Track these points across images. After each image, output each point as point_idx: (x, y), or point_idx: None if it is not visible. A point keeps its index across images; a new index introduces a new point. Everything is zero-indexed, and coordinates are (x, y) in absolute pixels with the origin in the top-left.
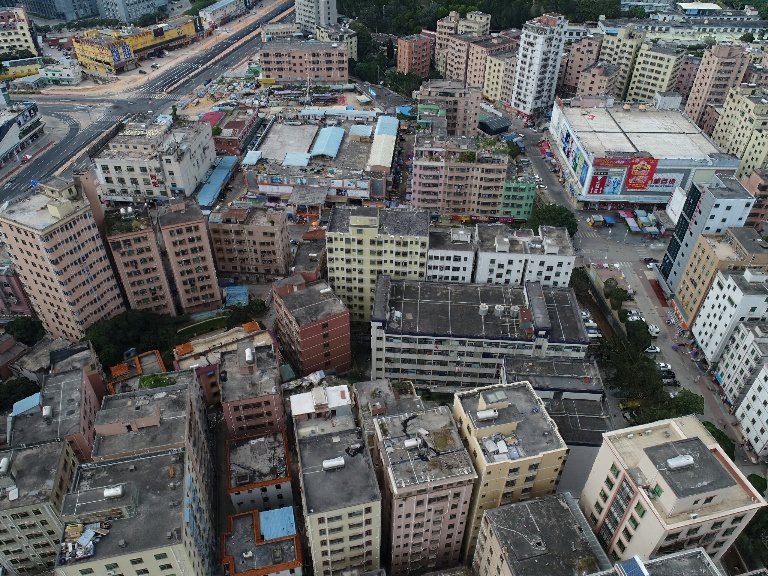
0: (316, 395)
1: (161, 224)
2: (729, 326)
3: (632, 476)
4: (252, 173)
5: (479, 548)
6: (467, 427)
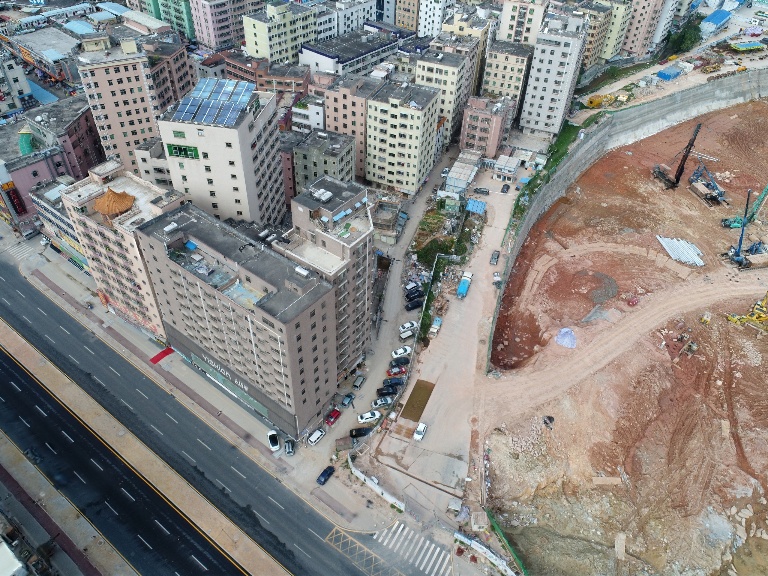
0: (381, 67)
1: (163, 57)
2: (441, 15)
3: (524, 2)
4: (73, 63)
5: (486, 78)
6: (459, 29)
